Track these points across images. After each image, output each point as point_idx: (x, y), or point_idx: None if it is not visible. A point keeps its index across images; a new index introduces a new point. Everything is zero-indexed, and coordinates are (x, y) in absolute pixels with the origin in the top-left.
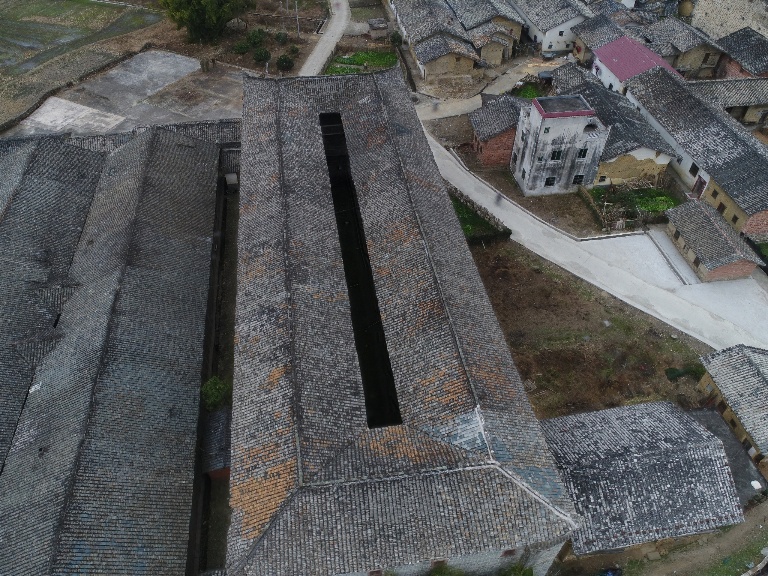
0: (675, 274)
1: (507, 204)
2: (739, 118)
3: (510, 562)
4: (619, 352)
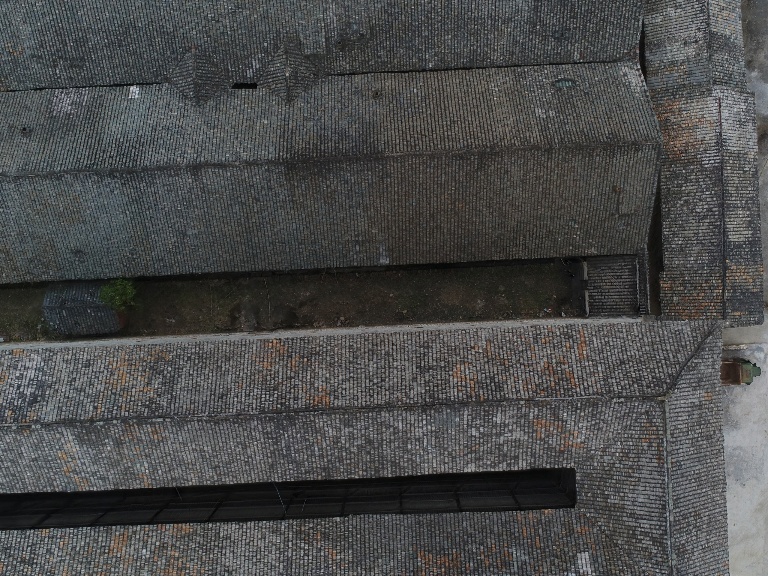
0: None
1: None
2: None
3: None
4: None
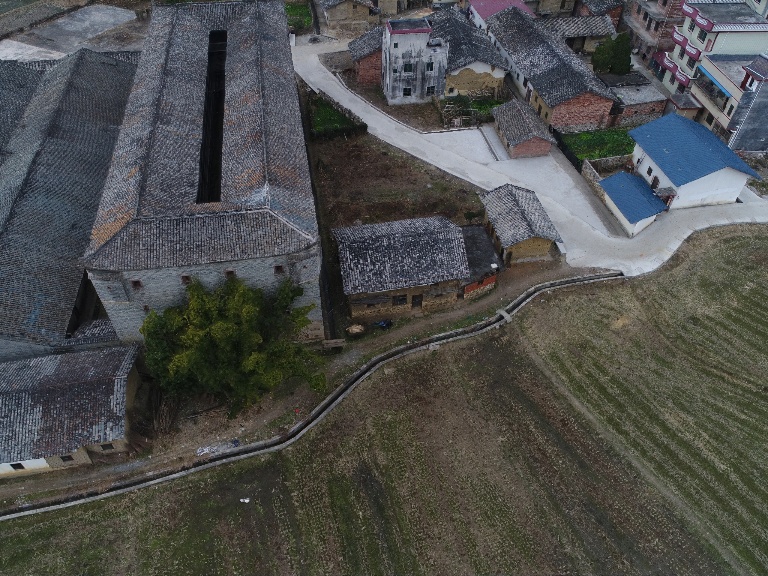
0: (492, 154)
1: (372, 110)
2: (580, 49)
3: (285, 282)
4: (432, 202)
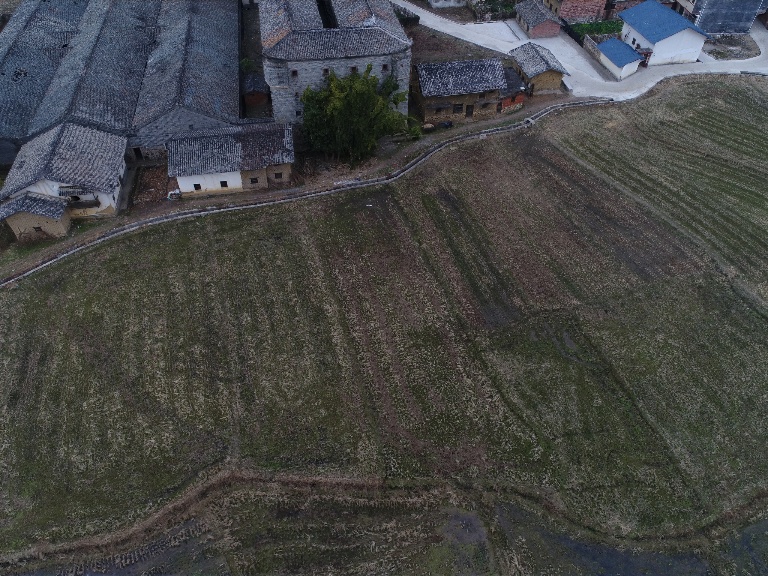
0: (515, 36)
1: (420, 10)
2: None
3: (387, 79)
4: None
